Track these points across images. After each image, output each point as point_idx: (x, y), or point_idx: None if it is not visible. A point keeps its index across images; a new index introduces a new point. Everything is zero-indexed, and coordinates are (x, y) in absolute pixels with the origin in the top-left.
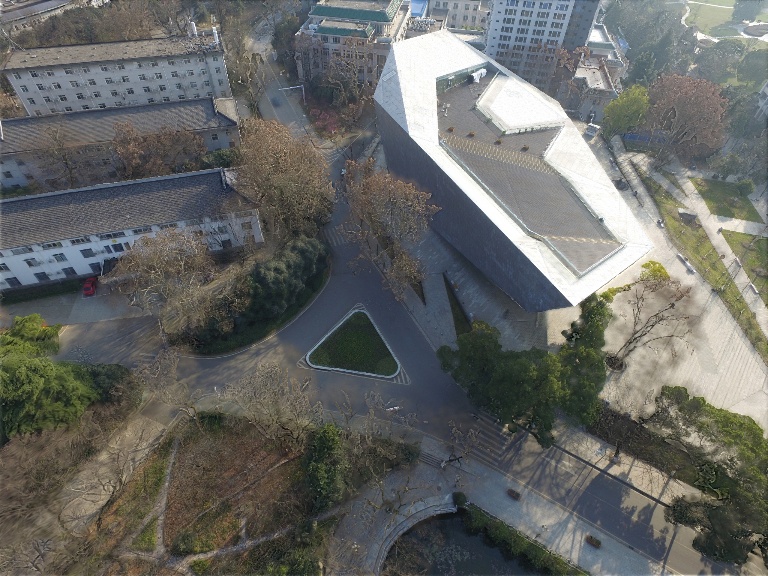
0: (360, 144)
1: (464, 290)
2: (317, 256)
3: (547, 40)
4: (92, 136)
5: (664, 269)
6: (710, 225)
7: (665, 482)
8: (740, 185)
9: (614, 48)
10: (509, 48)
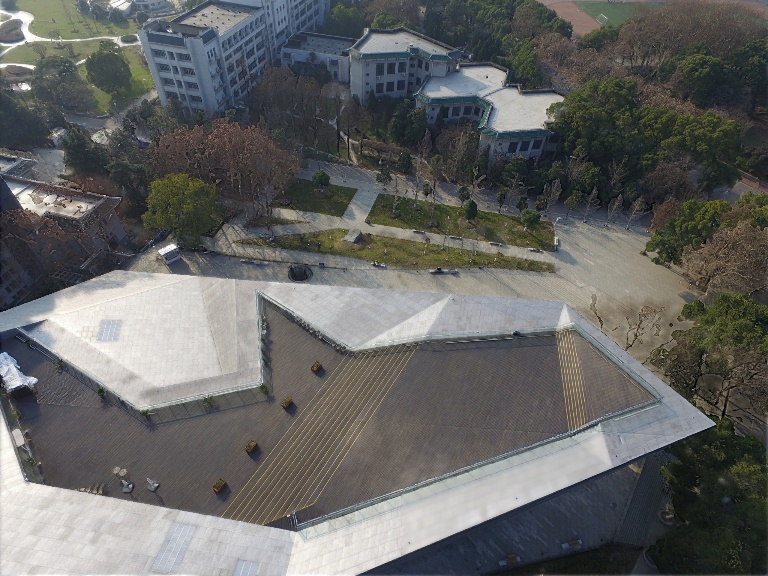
0: None
1: (515, 546)
2: None
3: None
4: None
5: None
6: (359, 226)
7: (703, 399)
8: (320, 180)
9: None
10: None
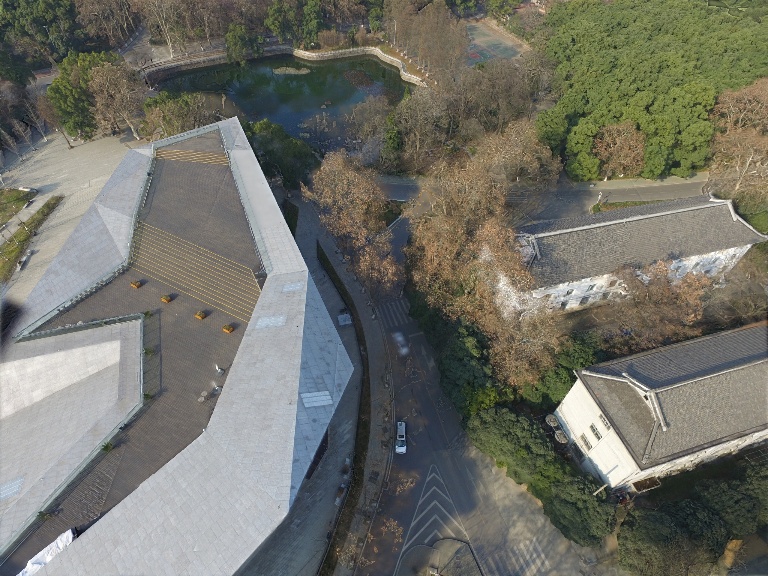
0: (374, 575)
1: None
2: None
3: None
4: (762, 332)
5: None
6: None
7: None
8: None
9: None
10: None
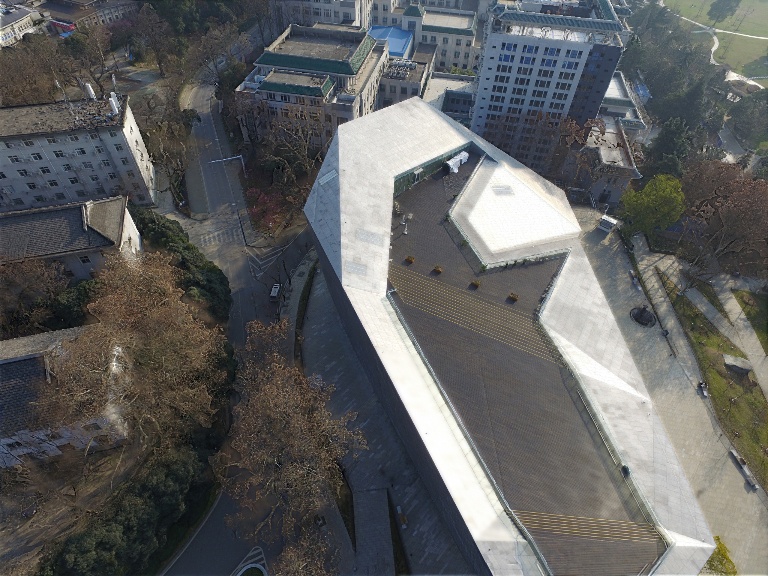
0: (307, 238)
1: (415, 525)
2: (188, 487)
3: (550, 103)
4: None
5: (727, 558)
6: (766, 376)
7: None
8: None
9: (634, 106)
10: (502, 111)
